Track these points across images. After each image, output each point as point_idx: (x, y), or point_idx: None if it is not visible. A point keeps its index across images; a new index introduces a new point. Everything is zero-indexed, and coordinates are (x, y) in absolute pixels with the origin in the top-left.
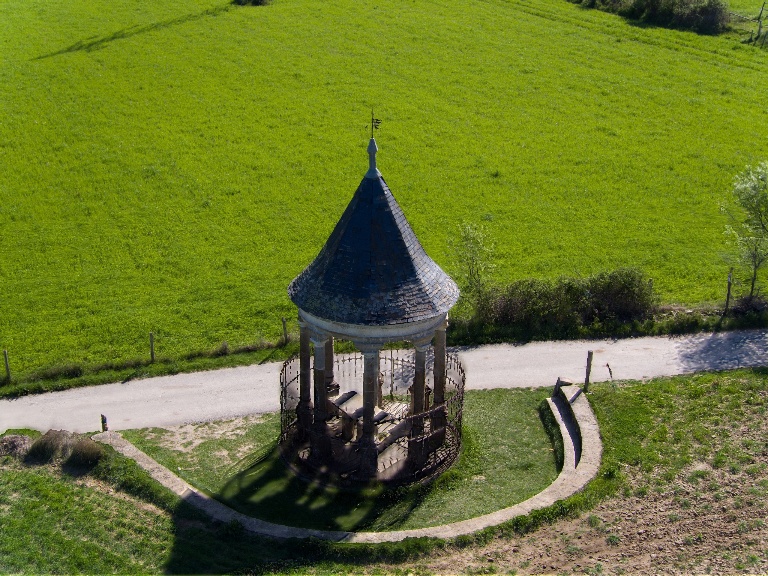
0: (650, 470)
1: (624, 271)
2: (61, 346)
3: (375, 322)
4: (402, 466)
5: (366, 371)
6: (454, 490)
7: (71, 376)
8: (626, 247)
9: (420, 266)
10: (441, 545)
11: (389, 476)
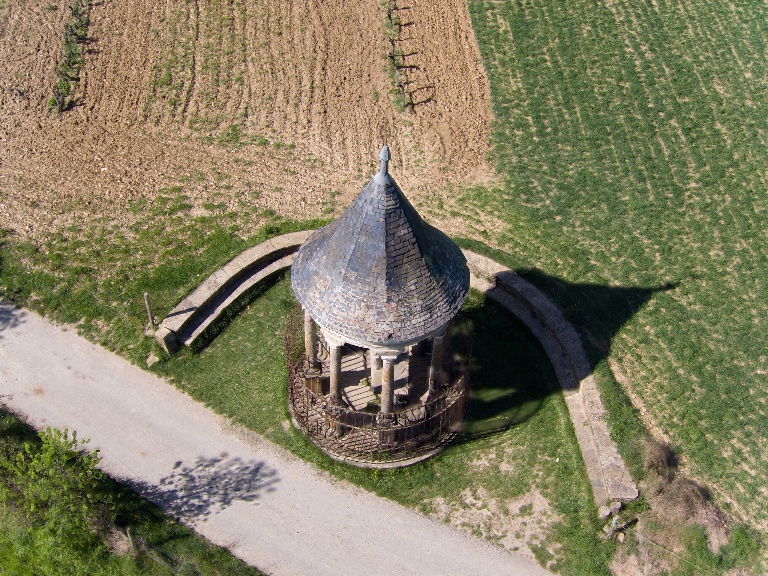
0: None
1: None
2: None
3: None
4: None
5: None
6: None
7: None
8: None
9: None
10: None
11: None
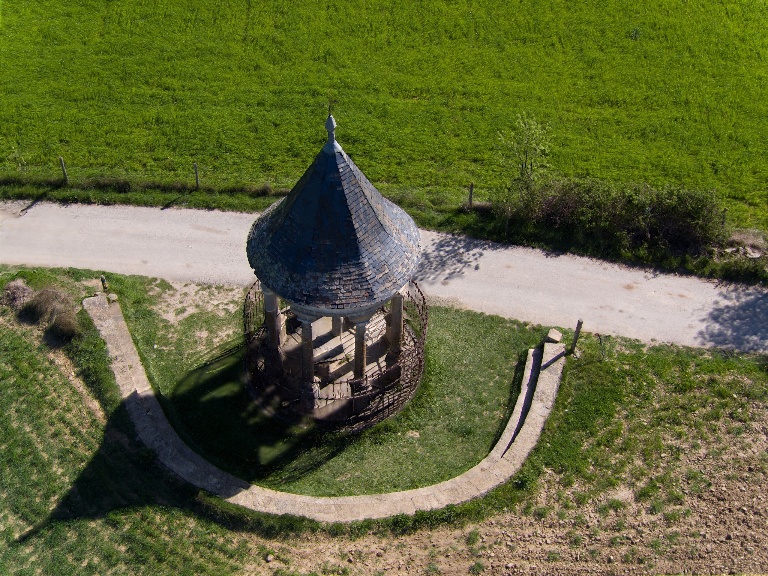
0: (569, 485)
1: (696, 195)
2: (129, 144)
3: (304, 302)
4: (343, 405)
5: (303, 332)
6: (381, 444)
7: (120, 189)
8: (762, 118)
9: (369, 247)
10: (314, 530)
11: (325, 416)
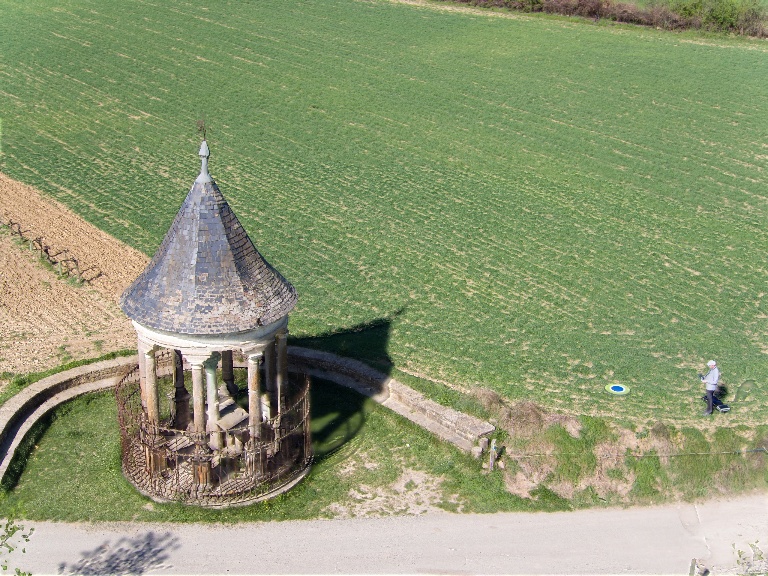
0: None
1: None
2: None
3: None
4: None
5: None
6: None
7: None
8: None
9: None
10: None
11: None
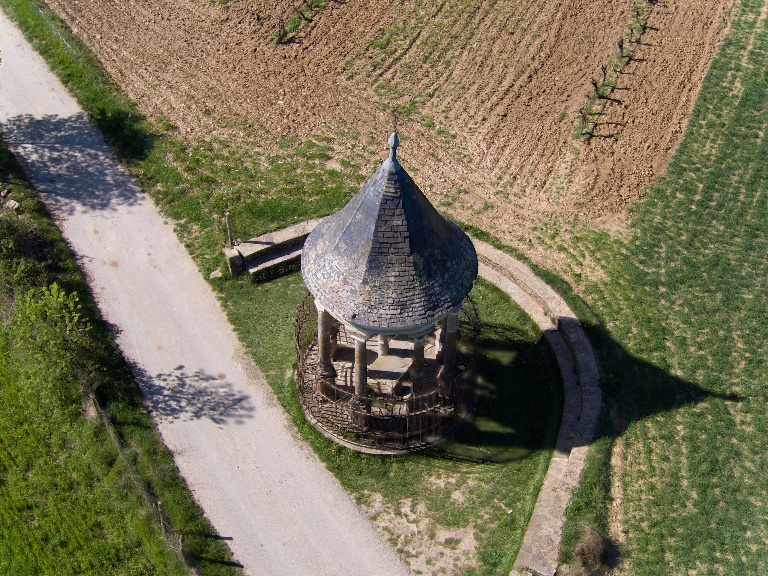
0: None
1: None
2: None
3: None
4: None
5: None
6: None
7: None
8: None
9: None
10: None
11: None
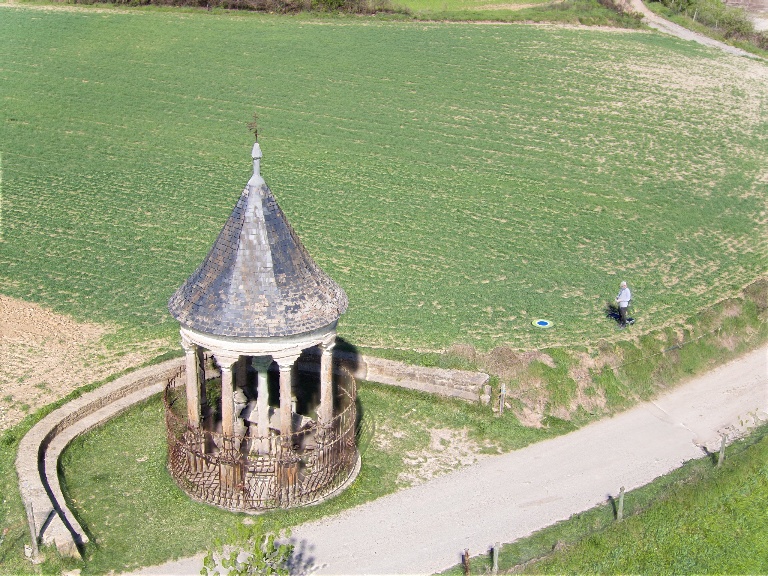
0: None
1: None
2: (762, 525)
3: None
4: None
5: None
6: None
7: None
8: None
9: None
10: None
11: None
